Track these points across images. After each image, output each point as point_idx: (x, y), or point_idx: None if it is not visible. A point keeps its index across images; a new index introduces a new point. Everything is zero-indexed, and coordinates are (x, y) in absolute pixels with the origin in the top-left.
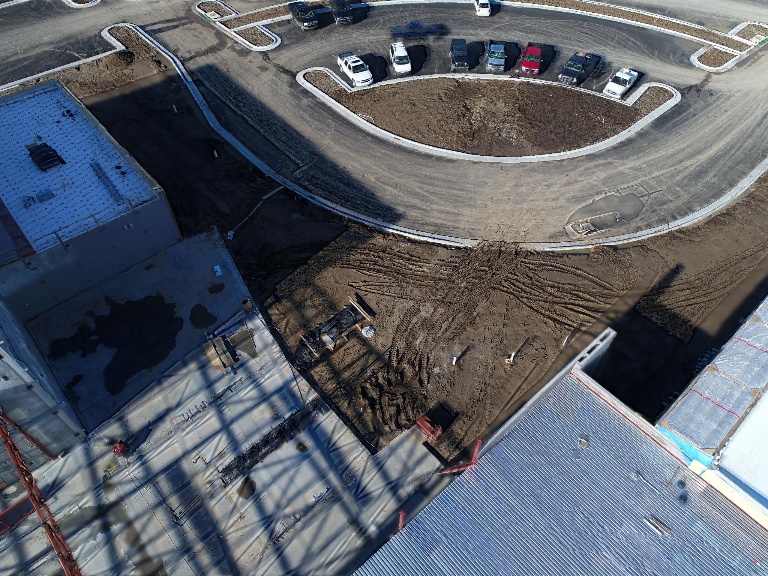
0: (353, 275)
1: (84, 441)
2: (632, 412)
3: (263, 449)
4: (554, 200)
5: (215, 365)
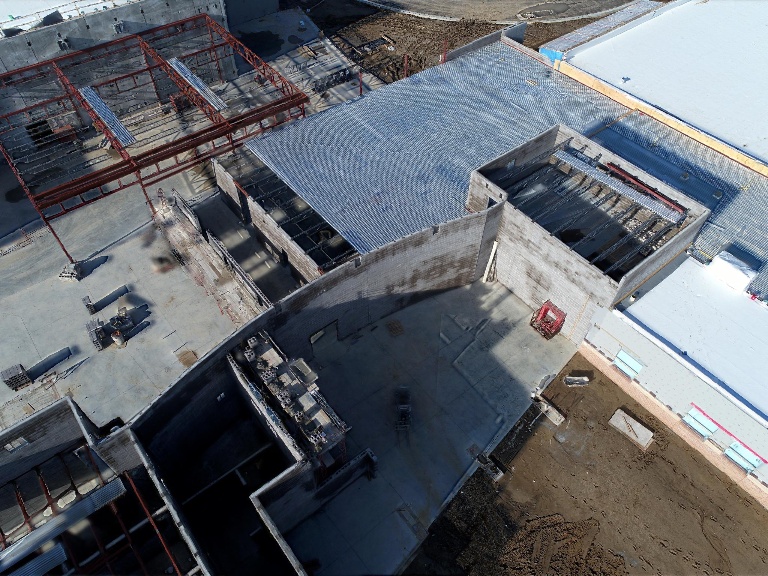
0: (383, 28)
1: (237, 78)
2: (529, 48)
3: (333, 83)
4: (512, 4)
5: (305, 55)
